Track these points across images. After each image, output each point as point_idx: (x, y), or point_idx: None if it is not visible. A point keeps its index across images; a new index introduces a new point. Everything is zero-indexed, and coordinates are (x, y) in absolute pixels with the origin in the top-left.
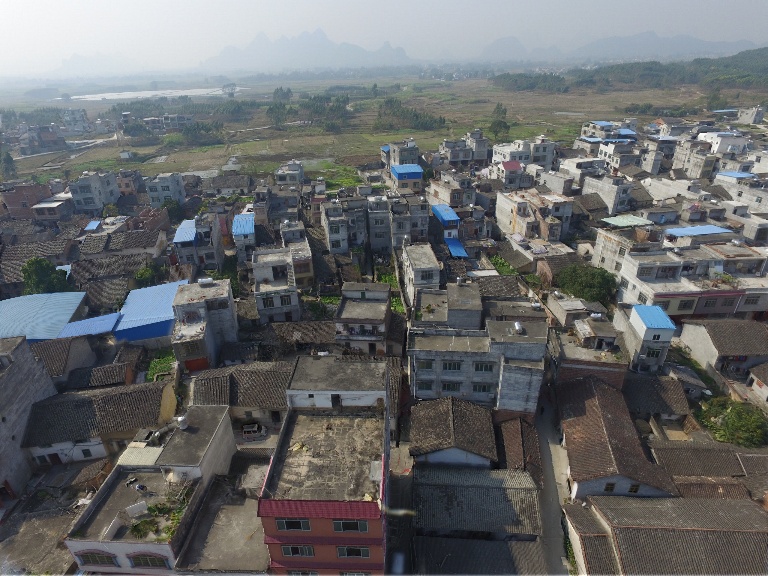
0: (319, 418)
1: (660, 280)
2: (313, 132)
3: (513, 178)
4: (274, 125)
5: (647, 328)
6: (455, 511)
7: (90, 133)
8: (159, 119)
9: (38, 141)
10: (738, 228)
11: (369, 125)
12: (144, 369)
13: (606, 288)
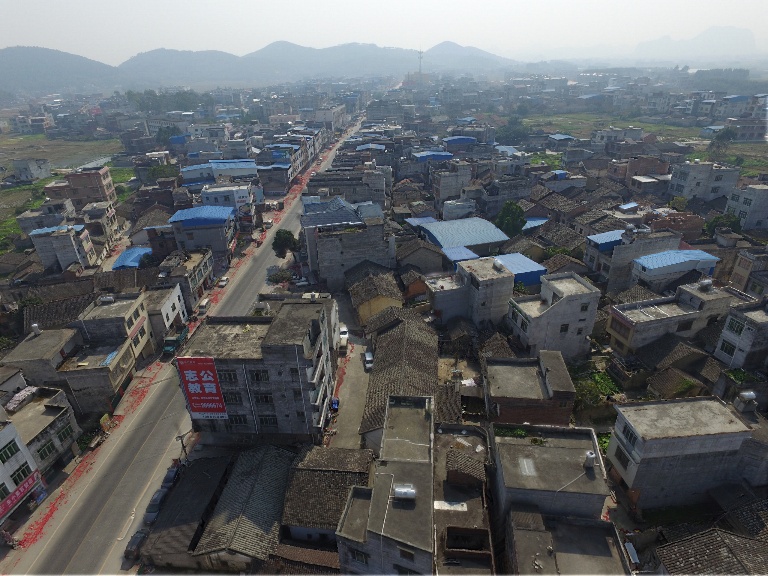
0: None
1: None
2: None
3: None
4: None
5: None
6: (238, 479)
7: None
8: None
9: None
10: None
11: None
12: None
13: None
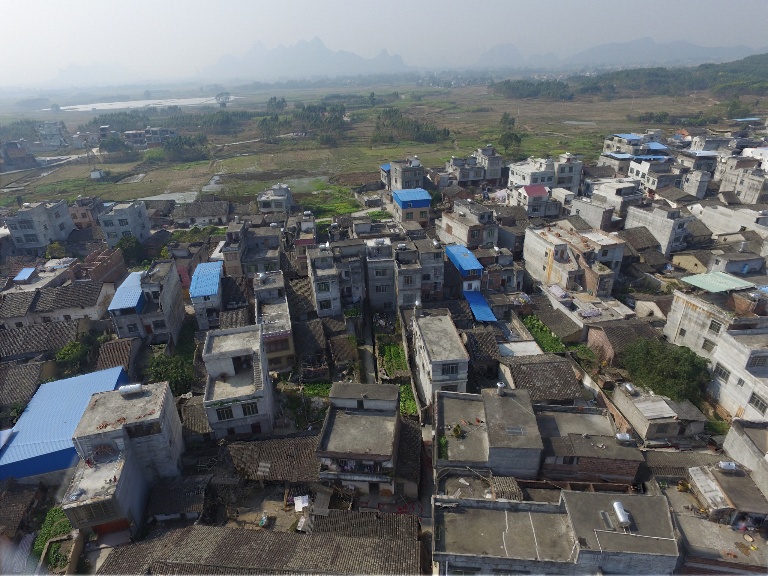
0: None
1: None
2: (306, 145)
3: (537, 205)
4: (265, 138)
5: None
6: None
7: (66, 148)
8: (141, 132)
9: (4, 158)
10: None
11: (367, 137)
12: (35, 526)
13: (696, 379)
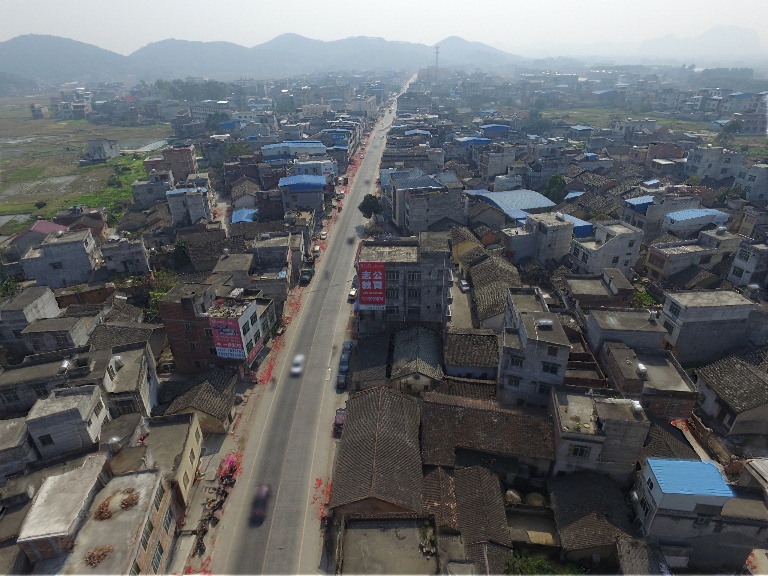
0: (415, 251)
1: None
2: None
3: None
4: None
5: None
6: (403, 343)
7: None
8: None
9: None
10: None
11: None
12: None
13: None
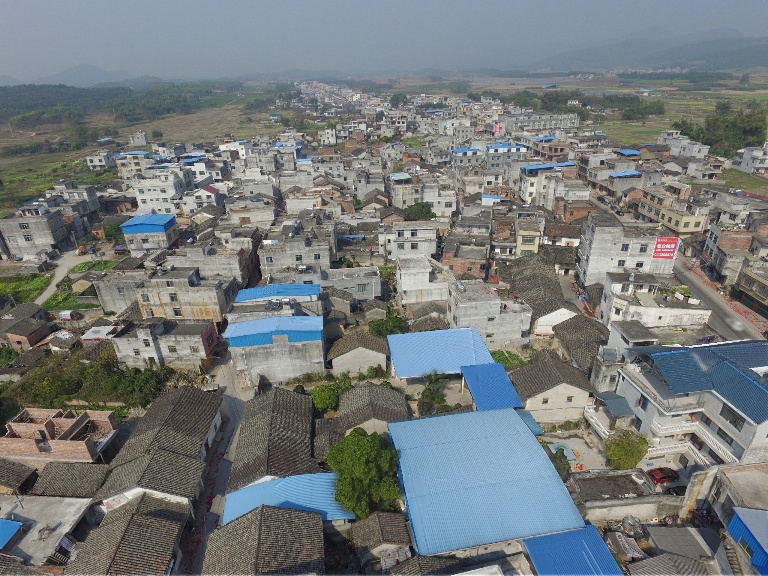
0: None
1: None
2: None
3: (218, 200)
4: None
5: None
6: None
7: None
8: None
9: None
10: (383, 175)
11: None
12: None
13: (430, 210)
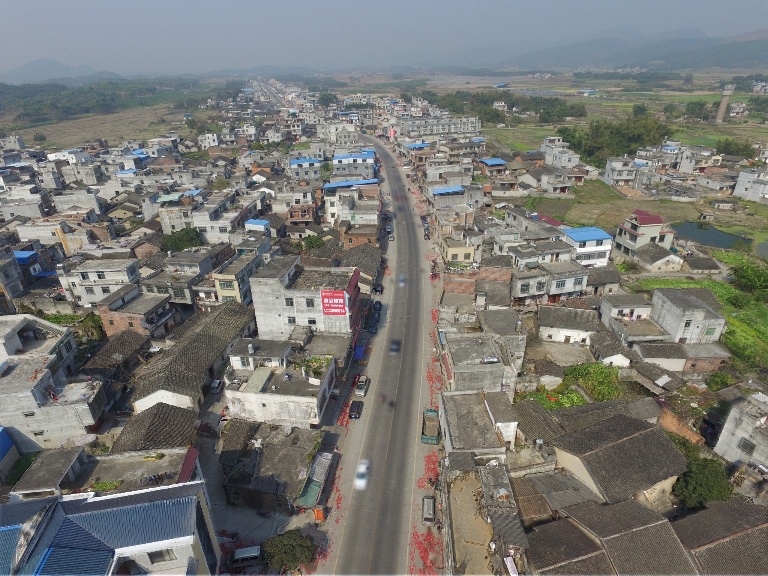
0: (294, 285)
1: (217, 219)
2: None
3: None
4: None
5: (264, 226)
6: None
7: None
8: None
9: None
10: None
11: None
12: None
13: (199, 237)
